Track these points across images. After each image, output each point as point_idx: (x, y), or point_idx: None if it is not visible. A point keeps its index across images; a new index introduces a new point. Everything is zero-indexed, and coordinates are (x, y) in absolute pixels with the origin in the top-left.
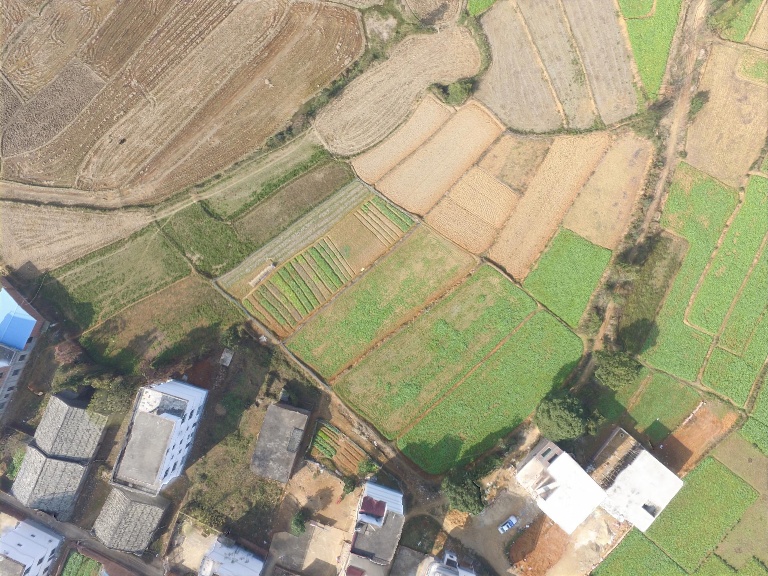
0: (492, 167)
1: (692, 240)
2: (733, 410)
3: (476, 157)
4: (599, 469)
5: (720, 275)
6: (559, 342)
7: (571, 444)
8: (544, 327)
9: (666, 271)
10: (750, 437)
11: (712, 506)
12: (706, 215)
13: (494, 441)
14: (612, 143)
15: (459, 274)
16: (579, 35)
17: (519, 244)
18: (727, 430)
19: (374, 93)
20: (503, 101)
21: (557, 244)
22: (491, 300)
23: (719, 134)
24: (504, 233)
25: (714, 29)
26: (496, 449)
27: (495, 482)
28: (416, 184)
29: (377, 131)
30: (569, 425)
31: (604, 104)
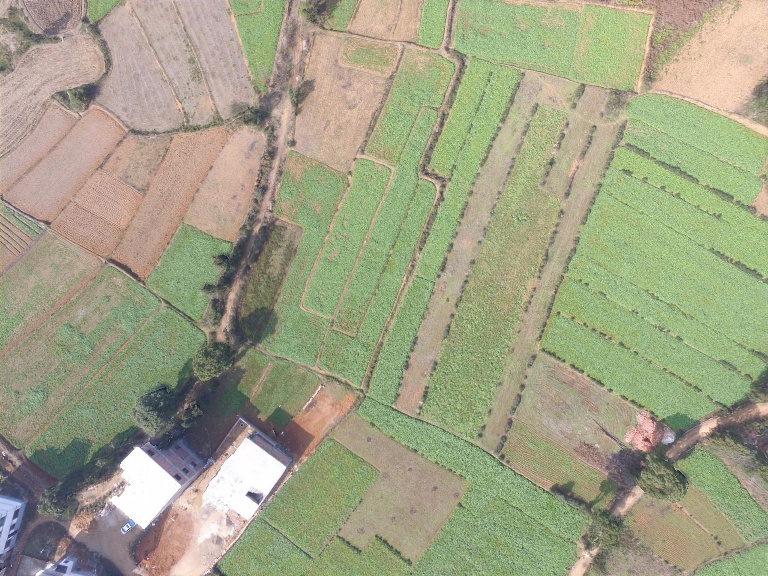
0: (116, 169)
1: (304, 226)
2: (351, 391)
3: (102, 161)
4: (218, 461)
5: (332, 259)
6: (183, 337)
7: (163, 438)
8: (167, 323)
9: (282, 259)
10: (367, 416)
11: (333, 488)
12: (317, 201)
13: (121, 441)
14: (228, 137)
15: (87, 277)
16: (193, 34)
17: (143, 243)
18: (346, 411)
19: (1, 105)
20: (125, 104)
21: (178, 240)
22: (116, 301)
23: (326, 121)
24: (128, 233)
25: (315, 20)
26: (121, 449)
27: (122, 483)
28: (43, 191)
29: (5, 142)
30: (144, 419)
31: (221, 100)
